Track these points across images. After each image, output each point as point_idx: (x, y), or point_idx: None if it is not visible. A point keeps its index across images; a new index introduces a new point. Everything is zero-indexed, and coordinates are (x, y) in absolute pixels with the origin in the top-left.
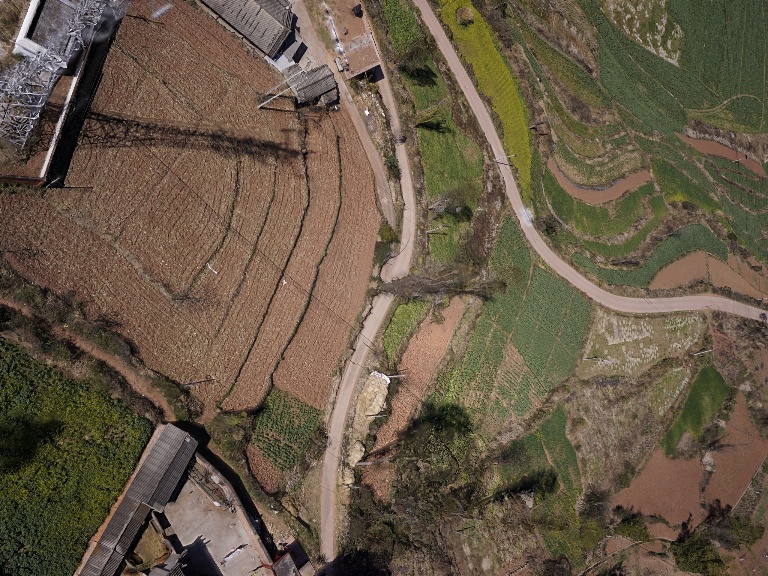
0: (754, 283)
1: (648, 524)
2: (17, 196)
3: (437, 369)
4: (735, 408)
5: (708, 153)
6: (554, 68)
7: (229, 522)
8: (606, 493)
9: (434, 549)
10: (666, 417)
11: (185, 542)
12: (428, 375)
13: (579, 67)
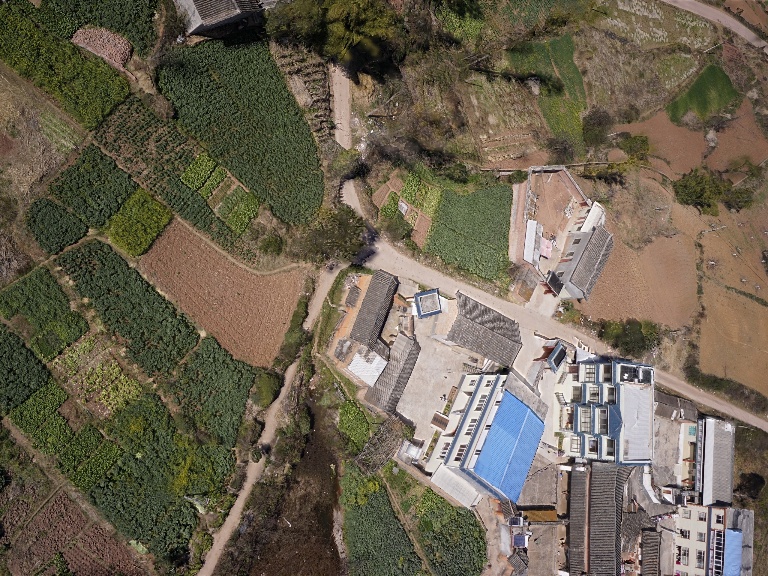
0: None
1: (650, 157)
2: None
3: None
4: (741, 109)
5: None
6: None
7: None
8: (610, 118)
9: (443, 80)
10: (672, 90)
11: None
12: None
13: None
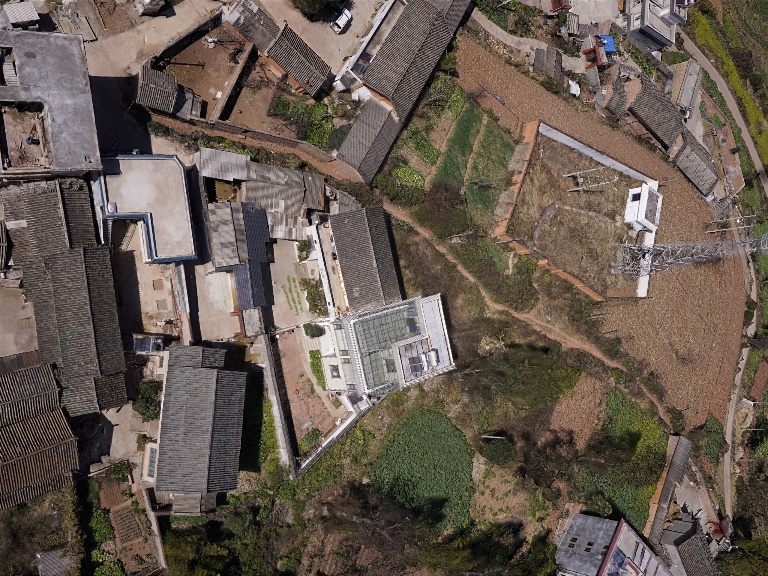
0: None
1: None
2: (627, 306)
3: (762, 394)
4: None
5: None
6: None
7: (695, 495)
8: None
9: (767, 517)
10: None
11: None
12: (759, 398)
13: None
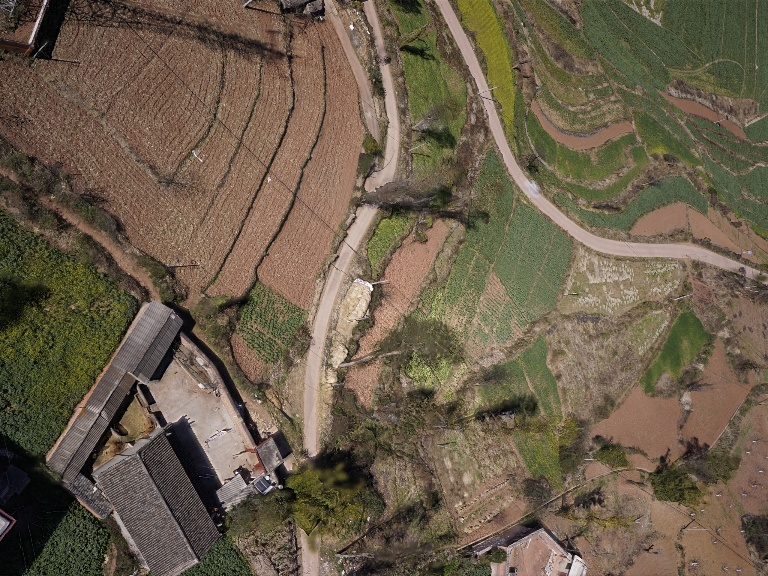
0: (734, 238)
1: (627, 454)
2: (5, 63)
3: (420, 287)
4: (713, 353)
5: (690, 113)
6: (538, 16)
7: (213, 405)
8: (586, 422)
9: (416, 459)
10: (646, 356)
11: (170, 420)
12: (411, 292)
13: (563, 17)
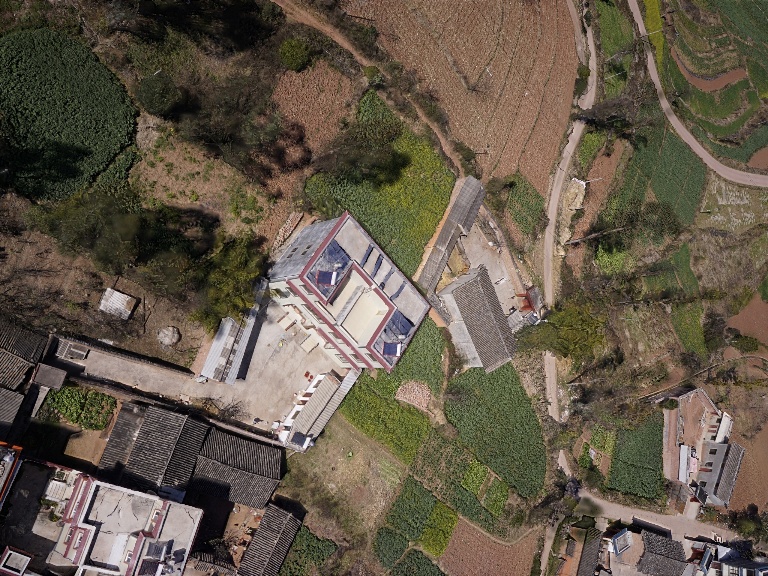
0: None
1: None
2: None
3: (607, 192)
4: None
5: None
6: None
7: (496, 260)
8: (721, 316)
9: (608, 325)
10: (762, 269)
11: (473, 266)
12: (601, 195)
13: None
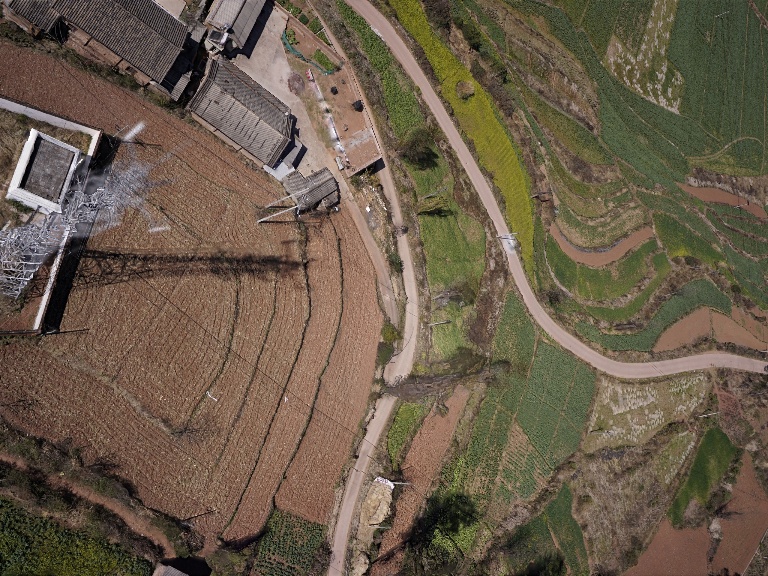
0: (758, 334)
1: None
2: (11, 347)
3: (441, 462)
4: (741, 470)
5: (710, 201)
6: (555, 129)
7: None
8: (613, 573)
9: None
10: (672, 485)
11: None
12: (432, 470)
13: (580, 125)
